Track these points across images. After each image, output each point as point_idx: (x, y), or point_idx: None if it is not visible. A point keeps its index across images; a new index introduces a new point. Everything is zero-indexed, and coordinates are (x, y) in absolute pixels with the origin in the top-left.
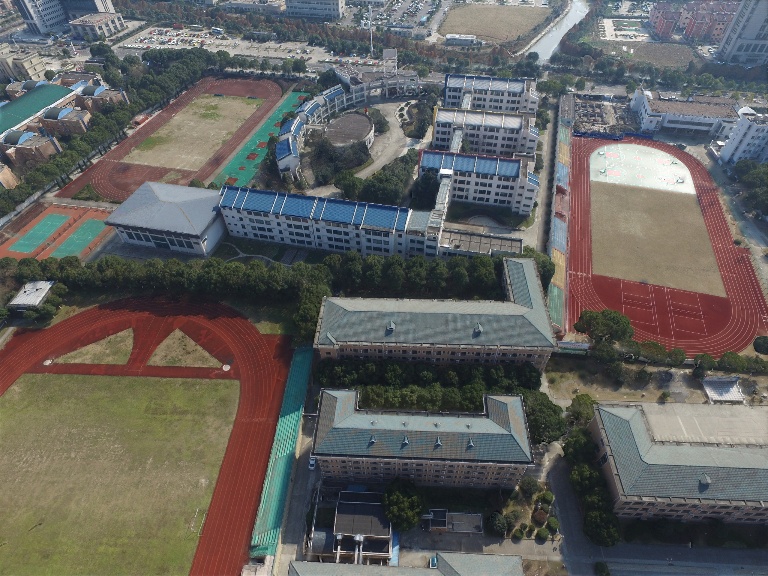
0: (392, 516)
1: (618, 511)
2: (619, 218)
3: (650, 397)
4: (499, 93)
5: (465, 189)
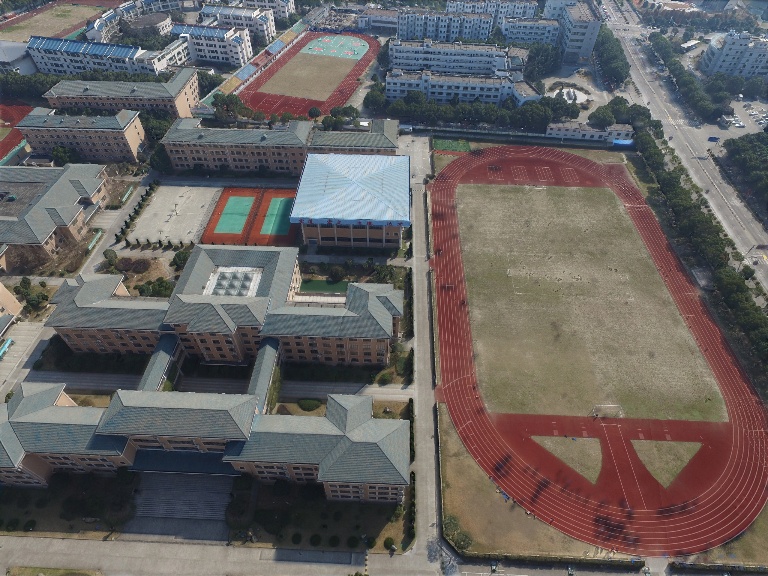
0: (53, 155)
1: (176, 162)
2: (298, 69)
3: None
4: (262, 0)
5: (202, 50)
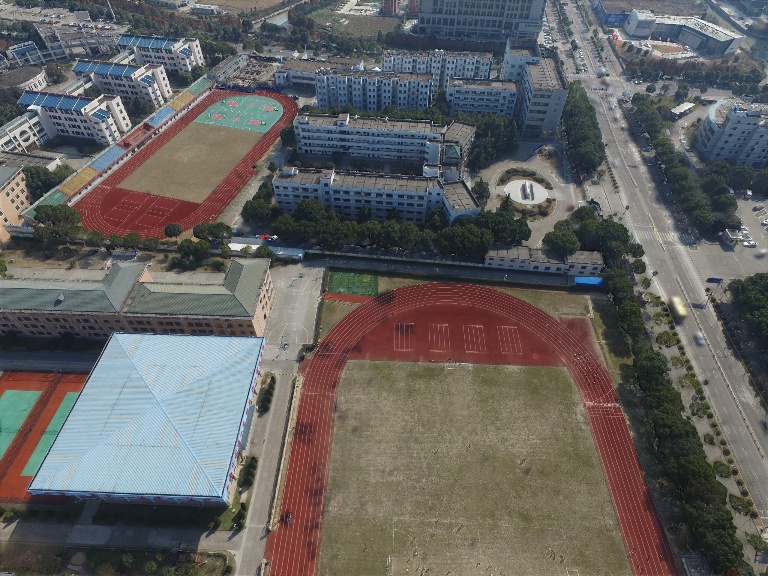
0: None
1: None
2: (182, 149)
3: (64, 265)
4: (158, 50)
5: (61, 124)
